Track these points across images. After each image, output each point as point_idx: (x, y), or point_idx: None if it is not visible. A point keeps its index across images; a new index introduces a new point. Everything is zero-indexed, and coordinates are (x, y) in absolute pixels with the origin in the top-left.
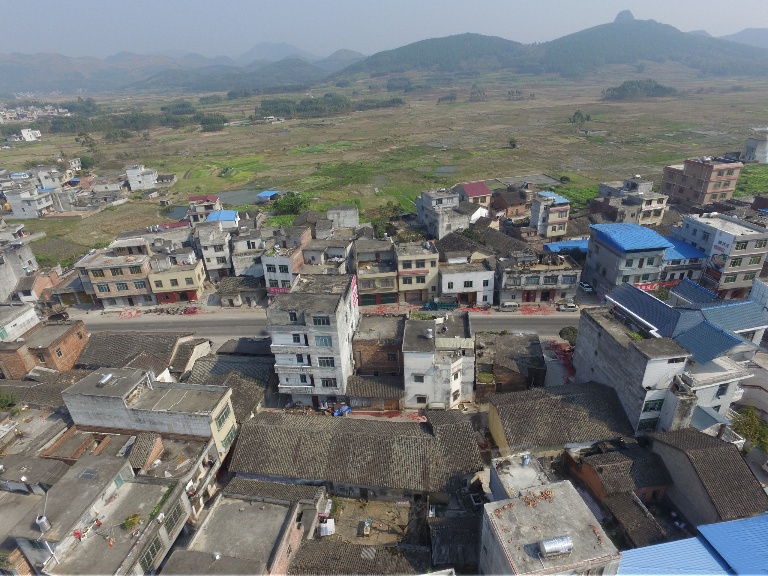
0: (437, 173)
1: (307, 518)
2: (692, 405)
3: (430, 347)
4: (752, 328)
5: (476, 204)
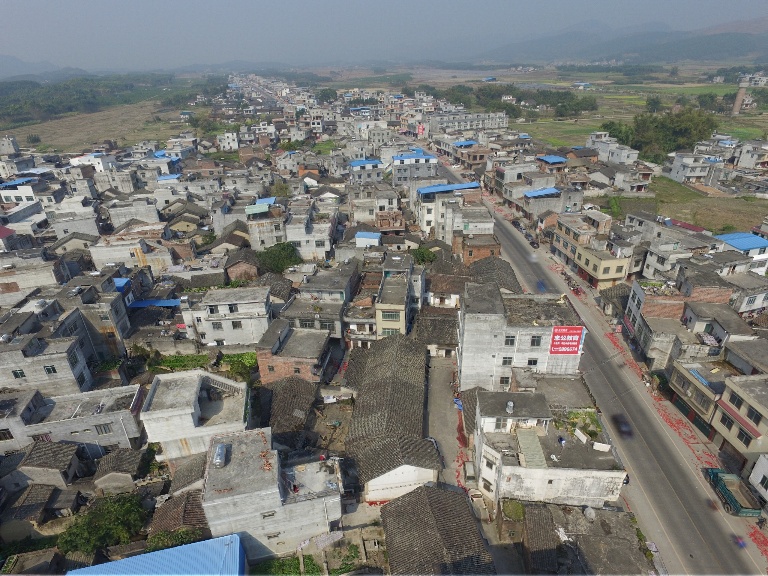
0: None
1: (336, 387)
2: None
3: (490, 412)
4: None
5: None
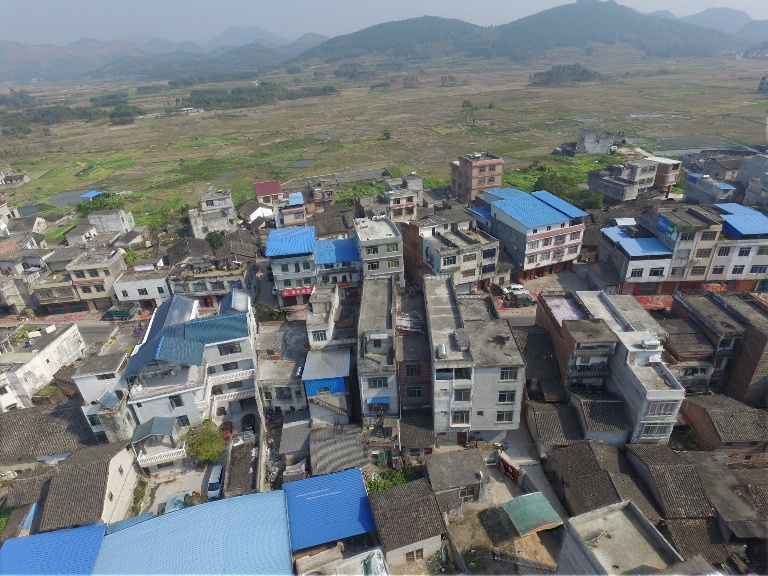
0: (288, 168)
1: None
2: (115, 419)
3: None
4: (229, 340)
5: (257, 204)
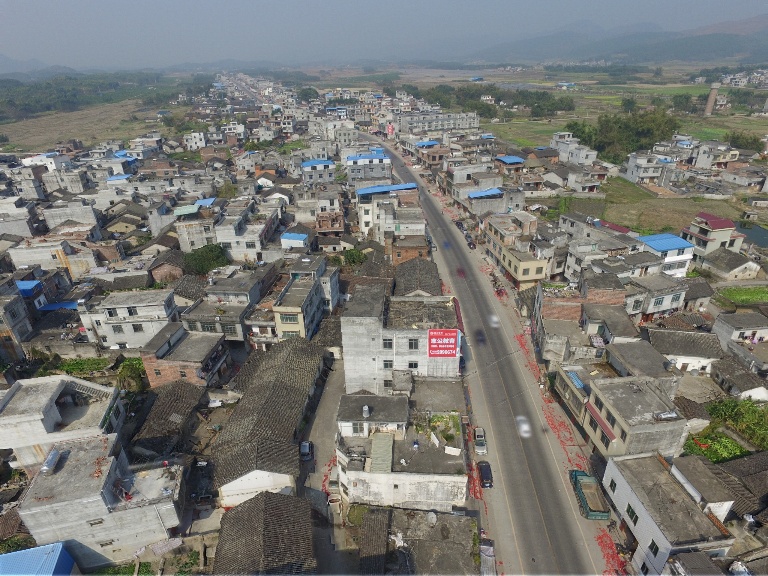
0: None
1: (224, 391)
2: None
3: (347, 416)
4: None
5: None
